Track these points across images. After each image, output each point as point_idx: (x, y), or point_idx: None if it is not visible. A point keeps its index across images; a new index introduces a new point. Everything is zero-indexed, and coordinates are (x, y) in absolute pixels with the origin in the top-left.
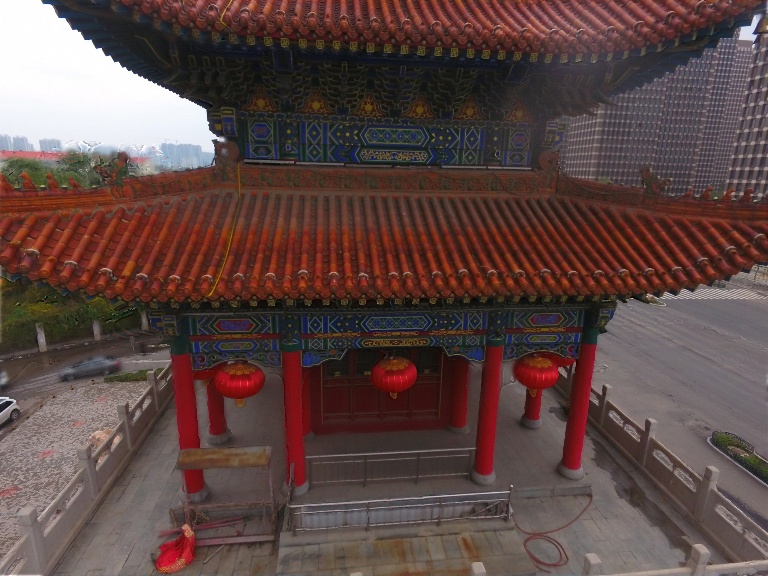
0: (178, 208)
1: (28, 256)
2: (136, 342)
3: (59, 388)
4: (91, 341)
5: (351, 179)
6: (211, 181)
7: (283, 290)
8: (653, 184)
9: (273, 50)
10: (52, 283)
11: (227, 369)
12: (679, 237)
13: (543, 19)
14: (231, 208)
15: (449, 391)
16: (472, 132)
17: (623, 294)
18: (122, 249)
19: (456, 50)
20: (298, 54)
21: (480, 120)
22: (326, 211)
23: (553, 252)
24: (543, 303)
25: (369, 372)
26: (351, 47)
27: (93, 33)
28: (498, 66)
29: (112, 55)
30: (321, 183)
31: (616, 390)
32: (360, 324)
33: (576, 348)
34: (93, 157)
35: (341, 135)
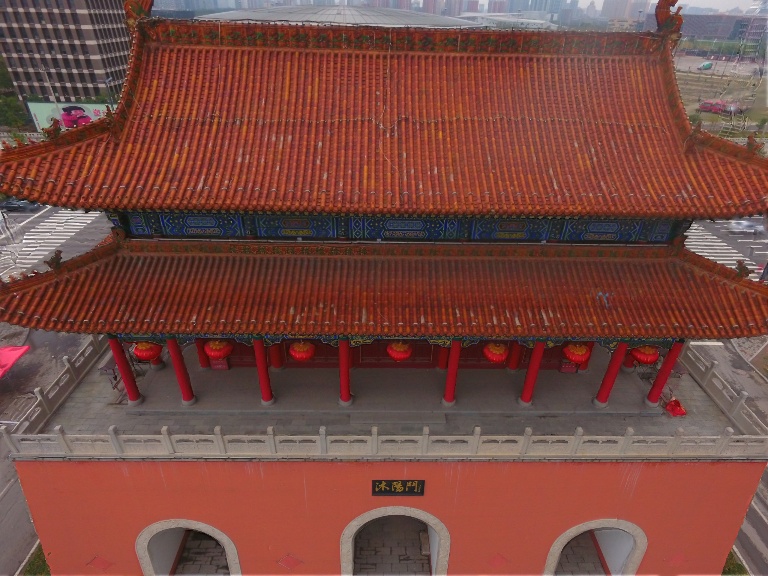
0: None
1: None
2: None
3: None
4: None
5: None
6: None
7: None
8: None
9: None
10: None
11: None
12: None
13: None
14: None
15: None
16: None
17: None
18: None
19: None
20: None
21: None
22: None
23: None
24: None
25: None
26: None
27: None
28: None
29: None
30: None
31: None
32: None
33: None
34: None
35: None
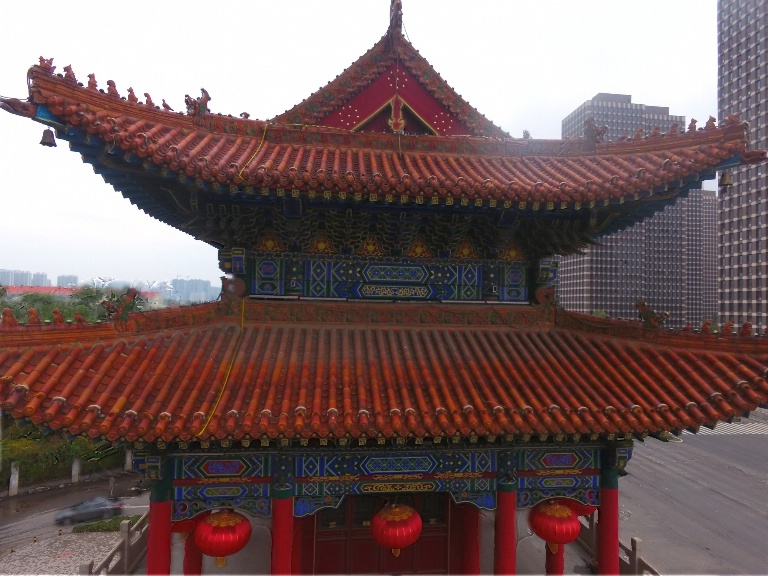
0: (179, 342)
1: (16, 392)
2: (116, 484)
3: (20, 540)
4: (67, 483)
5: (353, 313)
6: (215, 315)
7: (278, 428)
8: (651, 318)
9: (284, 199)
10: (35, 421)
11: (210, 519)
12: (687, 371)
13: (527, 174)
14: (232, 342)
15: (458, 546)
16: (469, 269)
17: (639, 432)
18: (115, 384)
19: (451, 199)
20: (307, 203)
21: (476, 259)
22: (327, 344)
23: (560, 386)
24: (554, 441)
25: (368, 522)
26: (356, 197)
27: (123, 186)
28: (490, 212)
29: (138, 204)
30: (323, 317)
31: (645, 542)
32: (359, 466)
33: (596, 493)
34: (105, 292)
35: (344, 272)
